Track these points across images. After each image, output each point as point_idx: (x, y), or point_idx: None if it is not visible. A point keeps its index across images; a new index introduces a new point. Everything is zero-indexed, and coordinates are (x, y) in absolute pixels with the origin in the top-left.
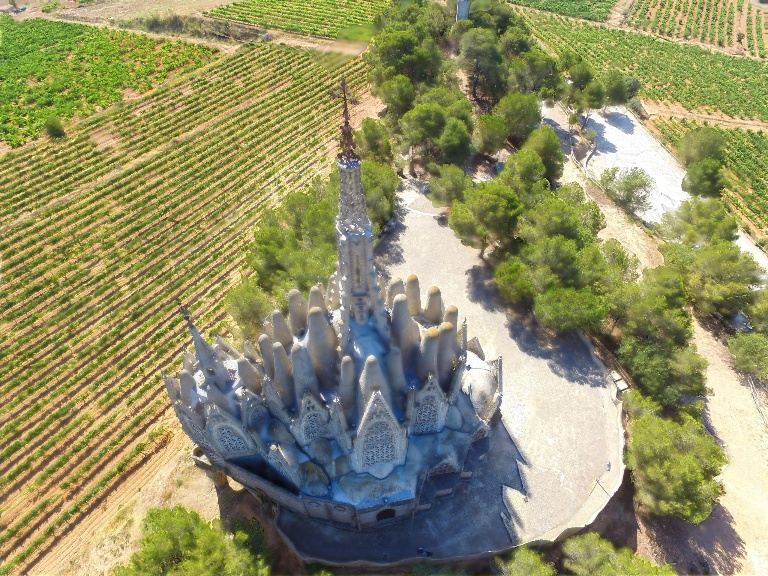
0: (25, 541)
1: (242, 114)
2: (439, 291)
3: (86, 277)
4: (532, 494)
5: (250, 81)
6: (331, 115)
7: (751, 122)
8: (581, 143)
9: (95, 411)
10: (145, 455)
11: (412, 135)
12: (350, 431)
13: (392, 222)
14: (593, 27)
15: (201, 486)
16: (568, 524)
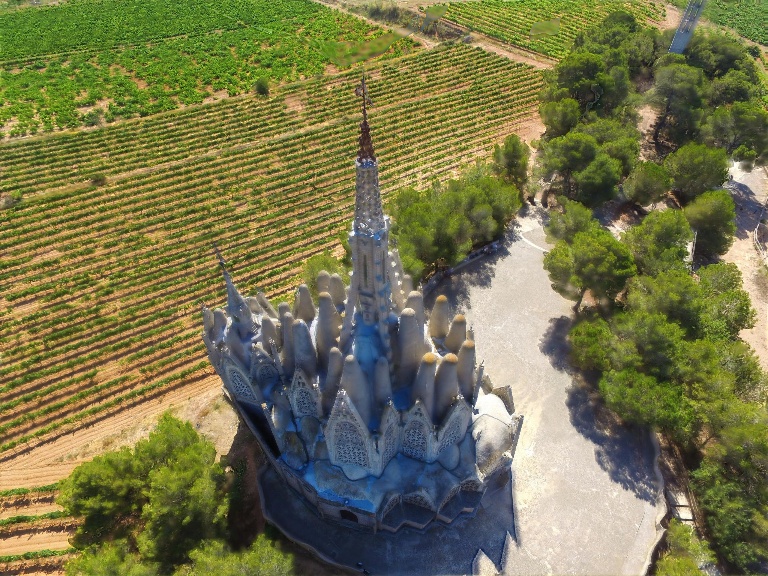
0: (103, 400)
1: (412, 107)
2: (464, 321)
3: (231, 213)
4: (507, 574)
5: (434, 78)
6: (493, 125)
7: None
8: None
9: (188, 322)
10: (205, 373)
11: (552, 162)
12: (324, 420)
13: (496, 244)
14: None
15: (230, 417)
16: None
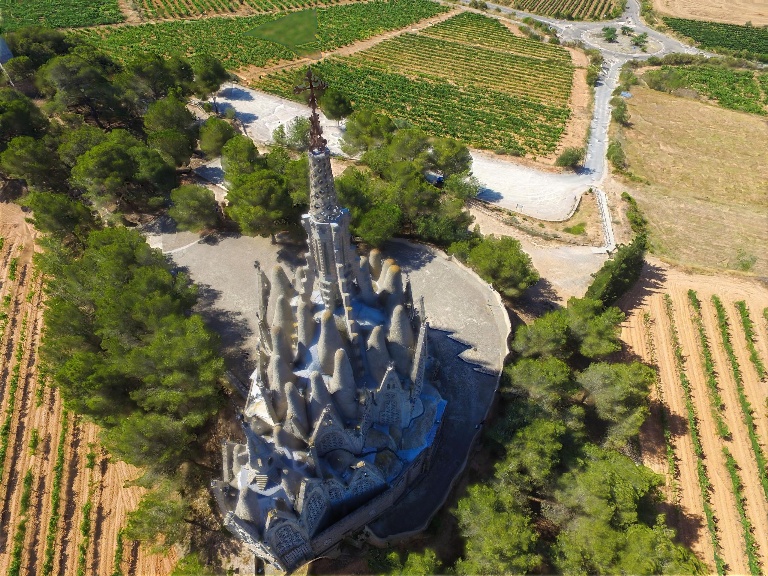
0: None
1: None
2: None
3: None
4: (474, 344)
5: None
6: None
7: (306, 59)
8: (231, 123)
9: None
10: None
11: (108, 184)
12: (404, 387)
13: (171, 271)
14: (120, 29)
15: None
16: (502, 339)
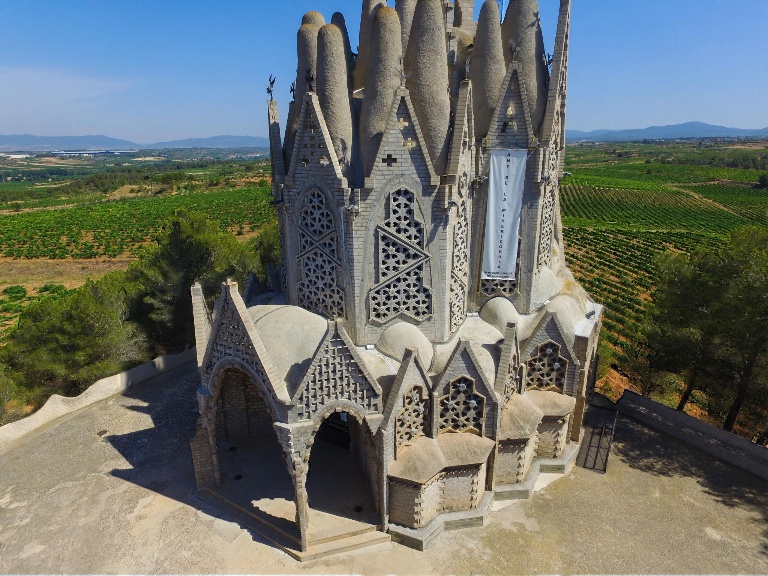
0: None
1: None
2: (377, 14)
3: None
4: (89, 444)
5: None
6: None
7: None
8: None
9: None
10: None
11: None
12: None
13: None
14: None
15: None
16: (6, 450)
